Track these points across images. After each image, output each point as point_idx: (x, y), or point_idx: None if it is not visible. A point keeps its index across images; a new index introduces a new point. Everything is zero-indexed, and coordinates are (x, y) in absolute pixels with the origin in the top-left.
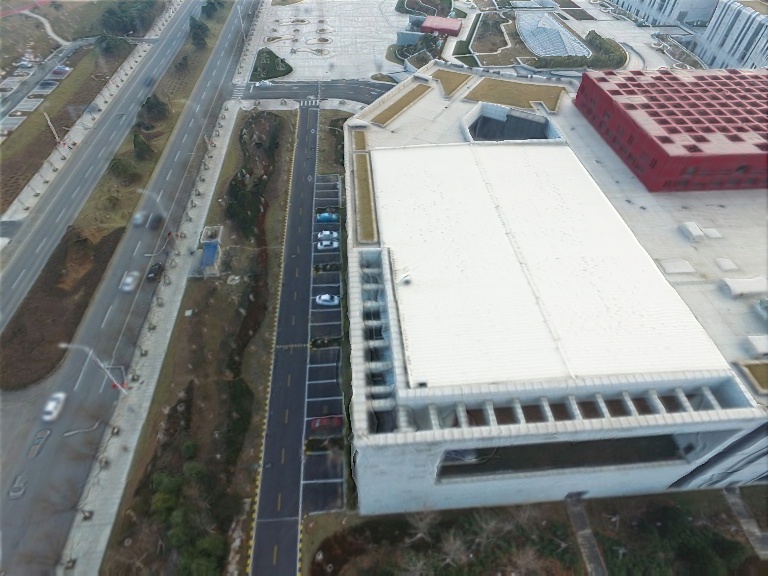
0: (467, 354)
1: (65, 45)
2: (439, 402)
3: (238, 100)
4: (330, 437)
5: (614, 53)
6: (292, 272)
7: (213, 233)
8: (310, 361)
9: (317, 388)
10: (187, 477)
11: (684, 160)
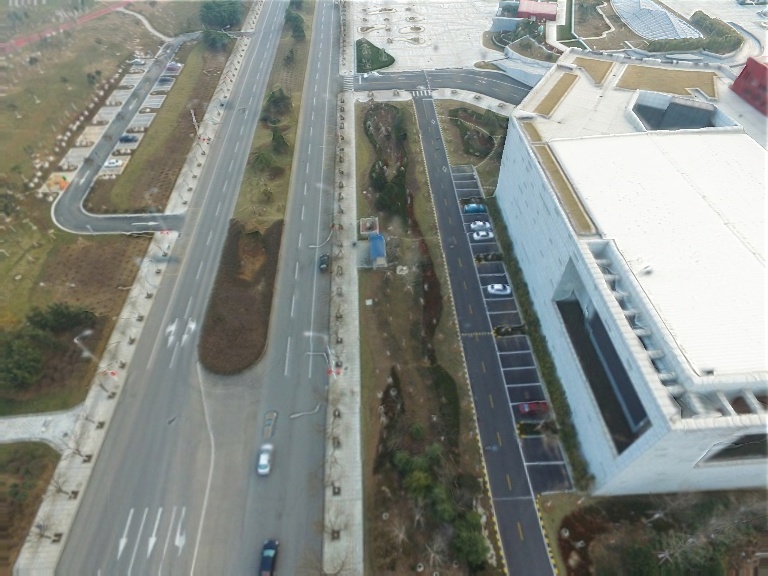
0: (739, 343)
1: (168, 41)
2: (728, 389)
3: (352, 92)
4: (543, 421)
5: (729, 34)
6: (455, 262)
7: (371, 225)
8: (499, 349)
9: (514, 375)
10: (436, 457)
11: None
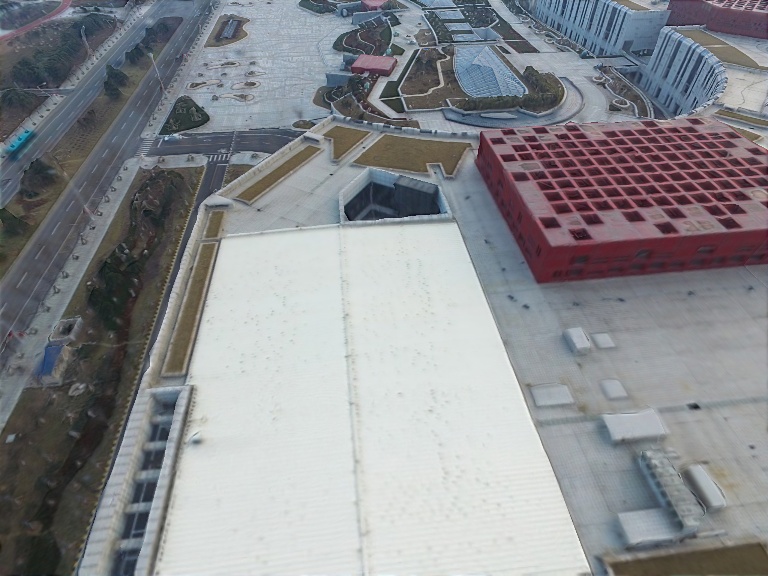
0: (237, 565)
1: None
2: None
3: (140, 158)
4: None
5: (549, 91)
6: None
7: (66, 329)
8: None
9: None
10: None
11: (570, 249)
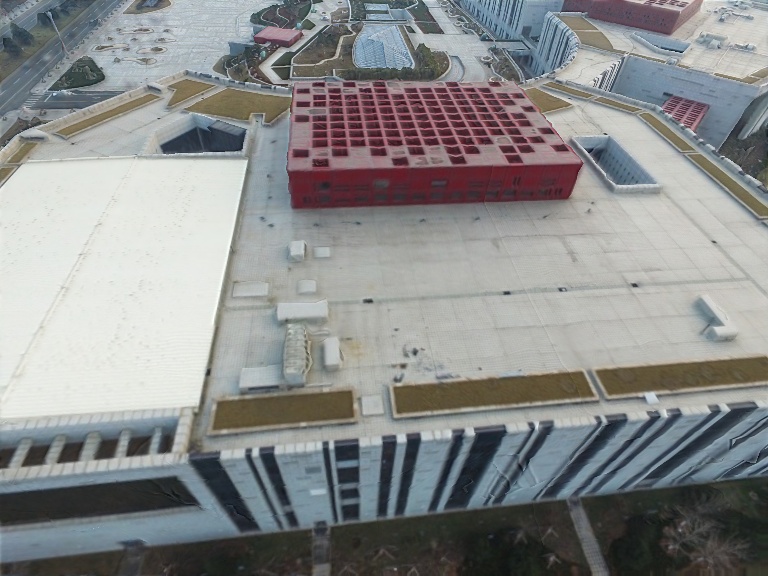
0: None
1: None
2: None
3: (22, 110)
4: None
5: (429, 66)
6: None
7: None
8: None
9: None
10: None
11: (307, 175)
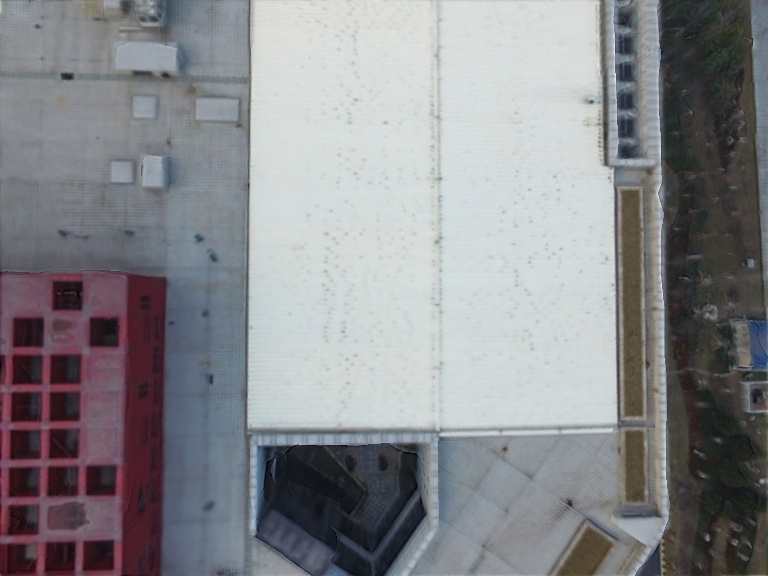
0: None
1: None
2: None
3: None
4: None
5: None
6: None
7: (759, 395)
8: None
9: None
10: None
11: None
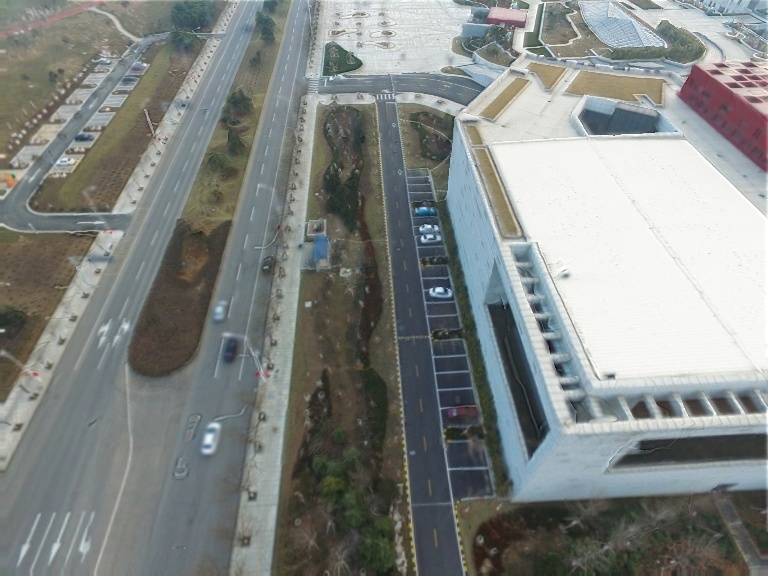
0: (646, 347)
1: (137, 41)
2: (629, 394)
3: (315, 94)
4: (470, 426)
5: (692, 43)
6: (400, 265)
7: (318, 226)
8: (434, 352)
9: (446, 379)
10: (351, 462)
11: None
